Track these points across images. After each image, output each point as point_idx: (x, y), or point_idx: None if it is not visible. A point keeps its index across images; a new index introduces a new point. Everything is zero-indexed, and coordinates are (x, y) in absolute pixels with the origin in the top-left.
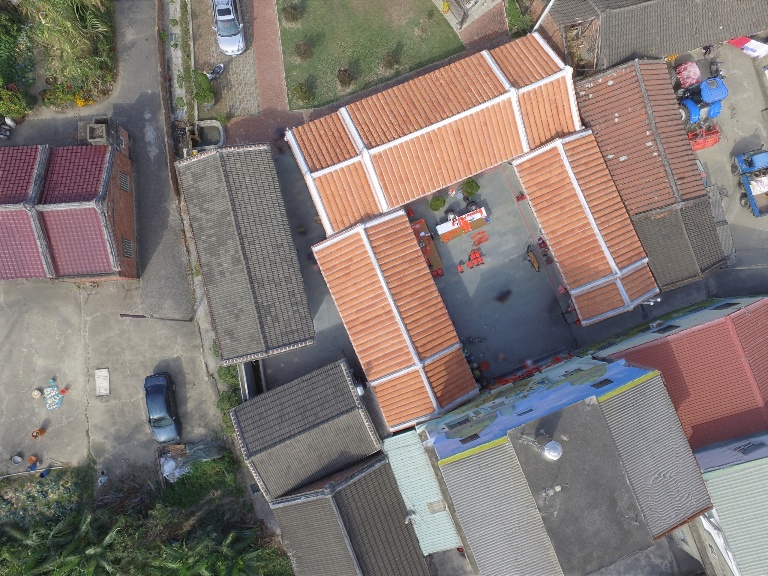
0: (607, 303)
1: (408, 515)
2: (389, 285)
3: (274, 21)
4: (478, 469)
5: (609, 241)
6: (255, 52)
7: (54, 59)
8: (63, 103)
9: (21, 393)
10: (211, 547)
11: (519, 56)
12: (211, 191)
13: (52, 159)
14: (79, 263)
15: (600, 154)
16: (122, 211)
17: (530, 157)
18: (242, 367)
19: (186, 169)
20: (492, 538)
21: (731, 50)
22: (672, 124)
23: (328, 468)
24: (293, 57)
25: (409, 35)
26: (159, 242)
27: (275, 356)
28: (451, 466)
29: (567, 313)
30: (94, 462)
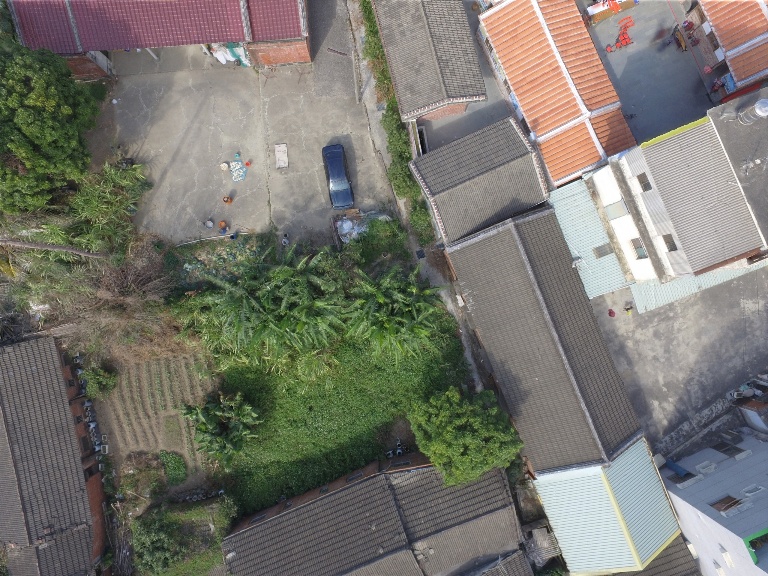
0: (763, 61)
1: (574, 260)
2: (556, 43)
3: None
4: (678, 150)
5: None
6: None
7: None
8: None
9: (210, 166)
10: (400, 278)
11: None
12: None
13: None
14: (272, 28)
15: None
16: None
17: None
18: (416, 128)
19: None
20: (692, 213)
21: None
22: None
23: (500, 215)
24: None
25: None
26: (328, 30)
27: (436, 133)
28: (652, 148)
29: (712, 93)
30: (275, 229)
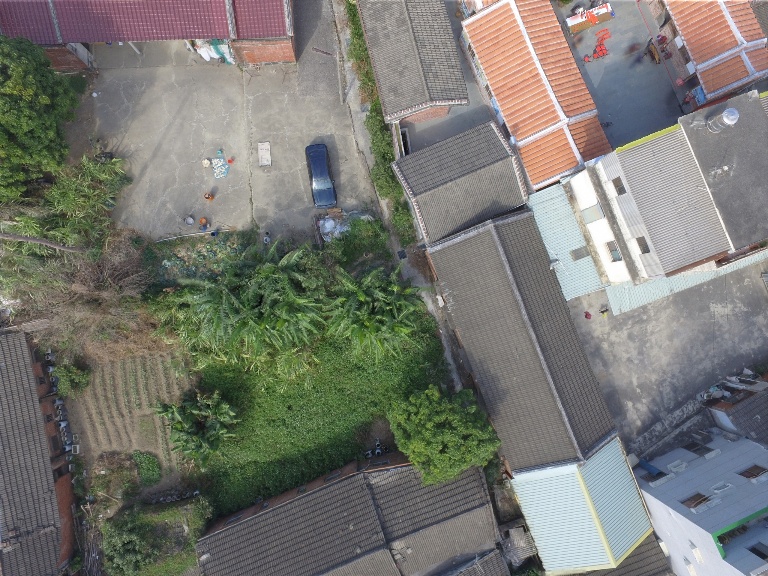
0: (731, 75)
1: (552, 262)
2: (536, 51)
3: None
4: (651, 155)
5: (734, 17)
6: None
7: None
8: None
9: (192, 163)
10: (381, 276)
11: None
12: None
13: None
14: (258, 27)
15: None
16: None
17: None
18: (399, 130)
19: None
20: (664, 216)
21: None
22: None
23: (480, 217)
24: None
25: None
26: (313, 31)
27: (419, 136)
28: (627, 153)
29: (684, 104)
30: (257, 227)
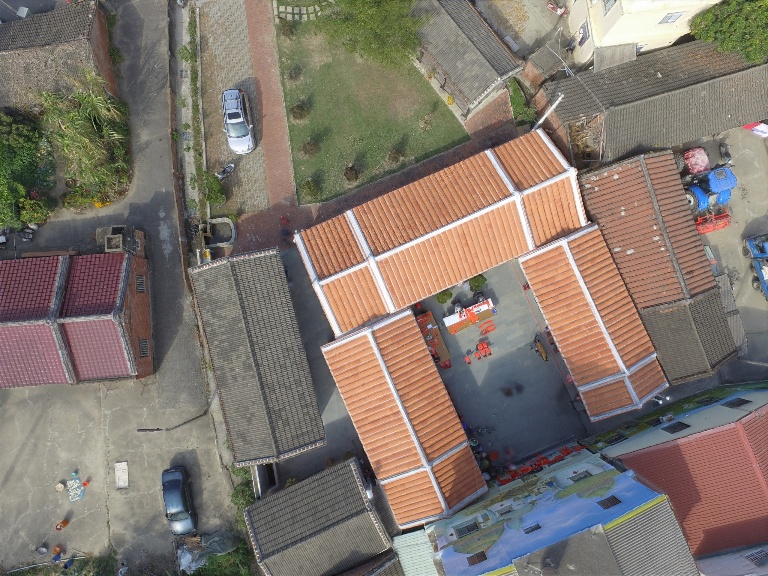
0: (615, 400)
1: None
2: (397, 387)
3: (282, 118)
4: None
5: (616, 338)
6: (264, 149)
7: (73, 162)
8: (82, 205)
9: (45, 486)
10: None
11: (523, 154)
12: (223, 298)
13: (72, 269)
14: (98, 369)
15: (606, 248)
16: (139, 313)
17: (536, 255)
18: (255, 465)
19: (199, 276)
20: None
21: (741, 130)
22: (680, 216)
23: (339, 567)
24: (301, 152)
25: (415, 127)
26: (174, 337)
27: None
28: None
29: (576, 401)
30: (114, 552)
